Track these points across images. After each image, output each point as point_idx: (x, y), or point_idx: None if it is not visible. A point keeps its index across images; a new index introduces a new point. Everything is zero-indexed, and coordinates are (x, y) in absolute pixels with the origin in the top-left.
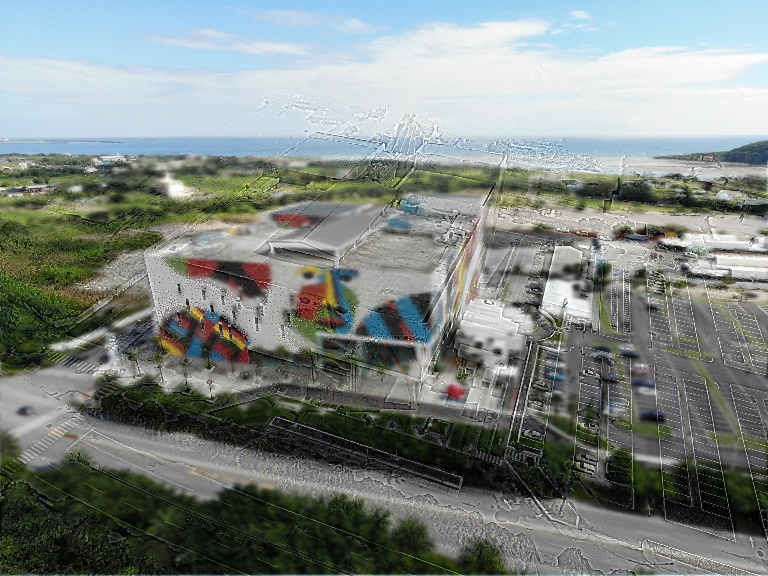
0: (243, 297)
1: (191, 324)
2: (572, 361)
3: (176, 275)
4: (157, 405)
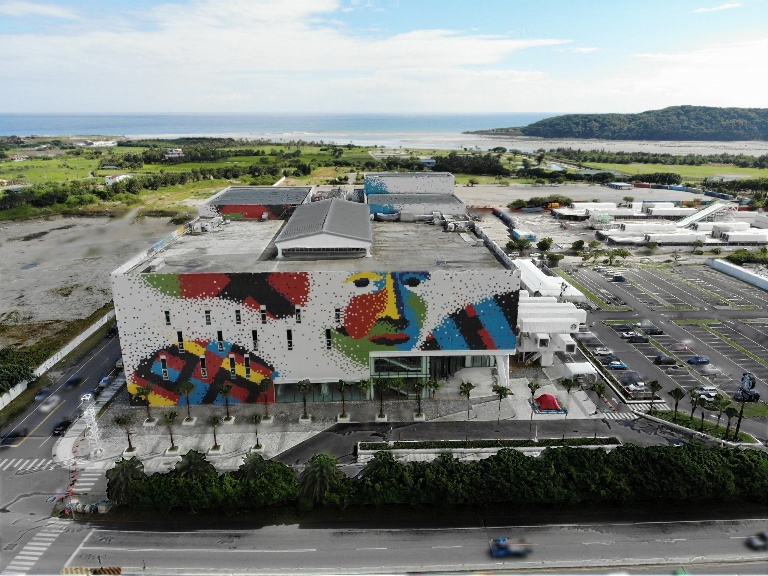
0: (270, 303)
1: (183, 371)
2: (605, 331)
3: (164, 298)
4: (204, 455)
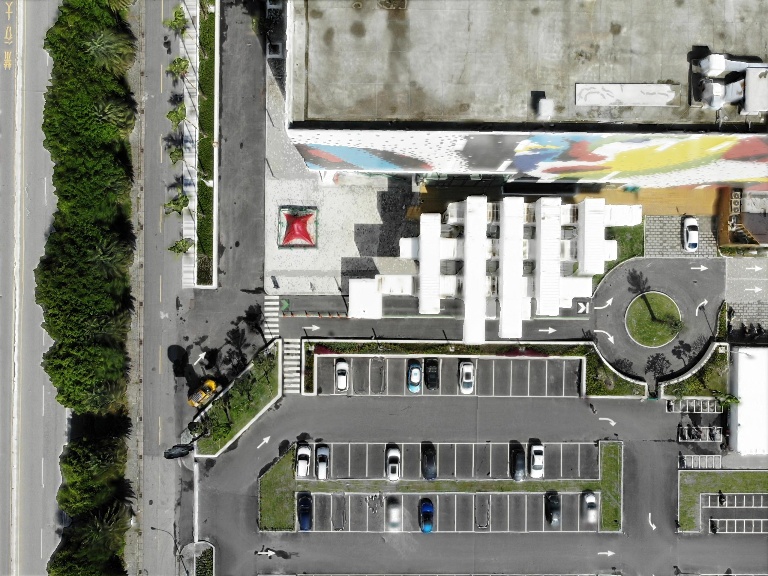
0: None
1: None
2: (568, 423)
3: None
4: None
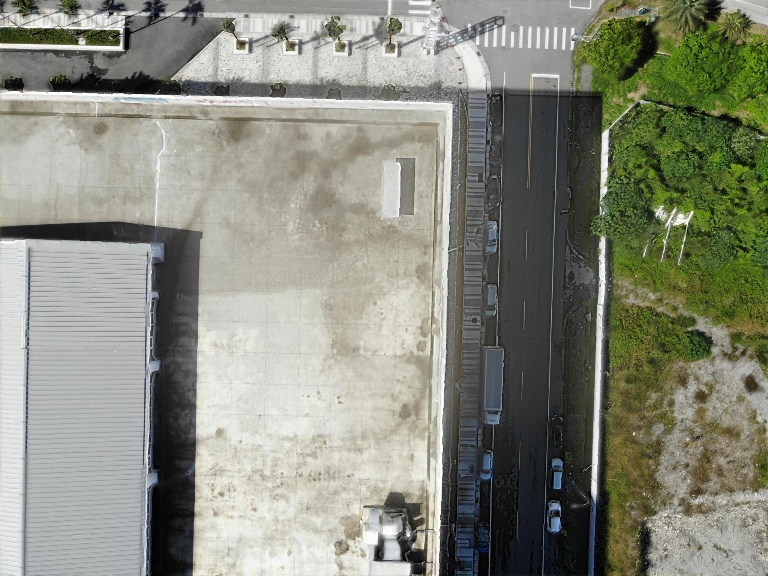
0: None
1: None
2: None
3: None
4: None
